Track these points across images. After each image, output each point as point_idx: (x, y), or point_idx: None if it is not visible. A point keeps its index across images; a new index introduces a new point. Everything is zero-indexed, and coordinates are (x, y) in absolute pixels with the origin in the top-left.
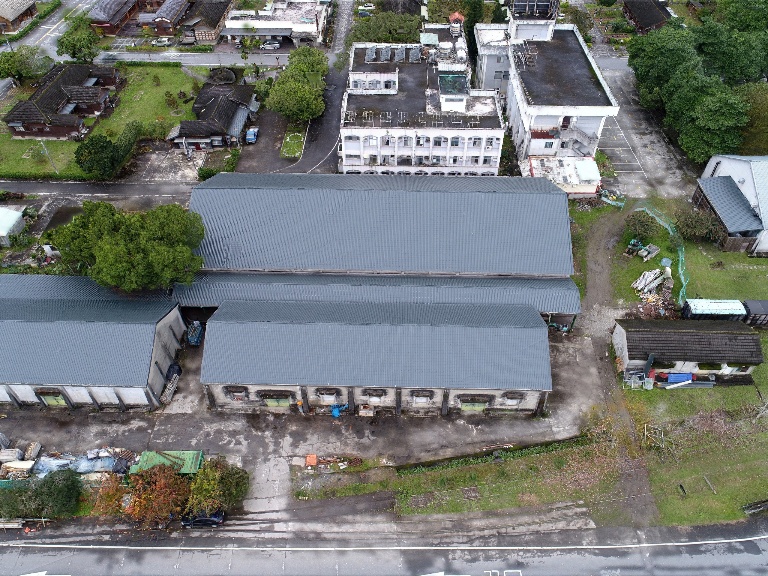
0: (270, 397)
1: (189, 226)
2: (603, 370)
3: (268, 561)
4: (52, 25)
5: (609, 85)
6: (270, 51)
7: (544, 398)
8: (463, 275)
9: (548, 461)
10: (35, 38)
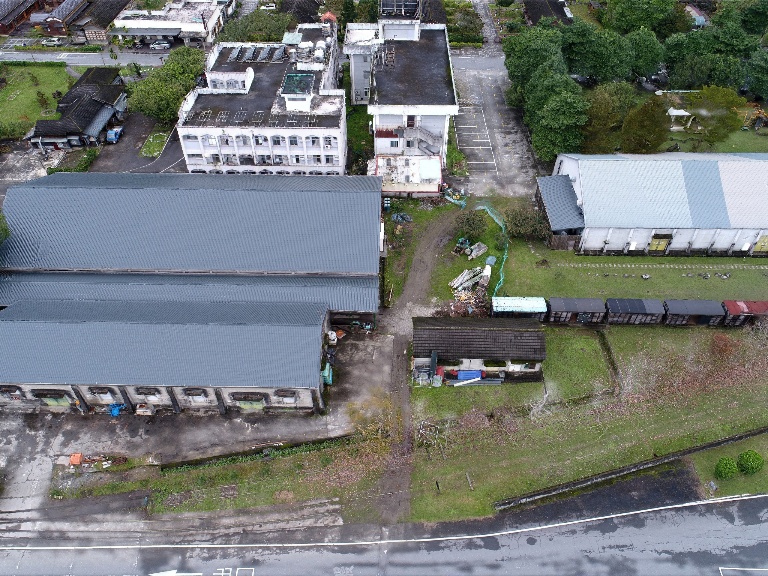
0: (43, 396)
1: None
2: (396, 368)
3: (4, 560)
4: None
5: (489, 85)
6: (160, 51)
7: (315, 396)
8: (271, 274)
9: (316, 459)
10: None
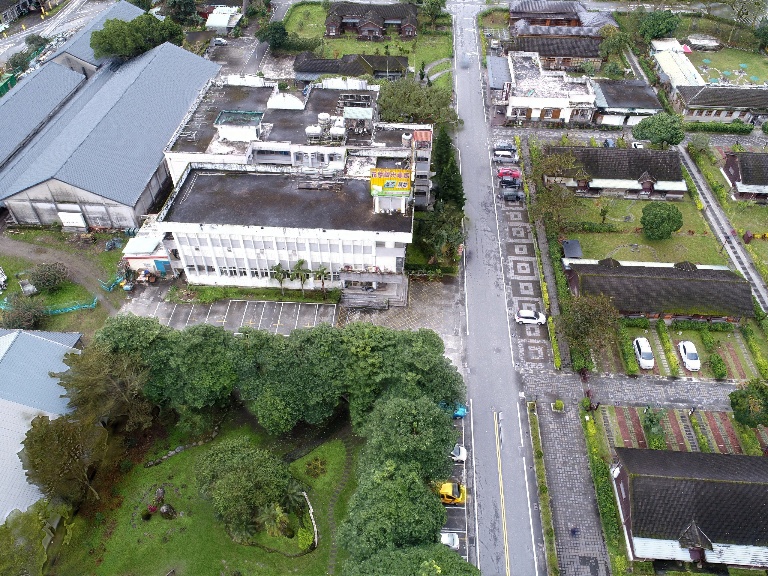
0: None
1: (115, 38)
2: None
3: None
4: None
5: None
6: None
7: None
8: None
9: None
10: None
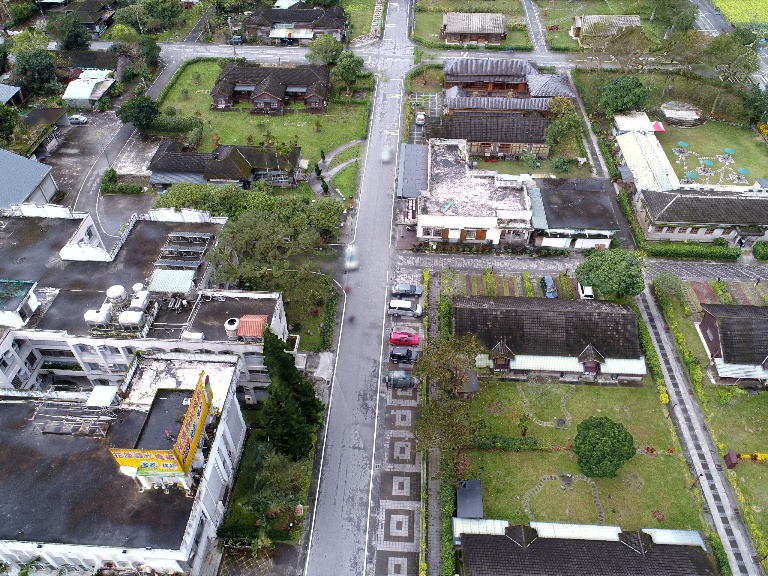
0: None
1: None
2: None
3: None
4: (469, 56)
5: None
6: None
7: None
8: None
9: None
10: (435, 54)
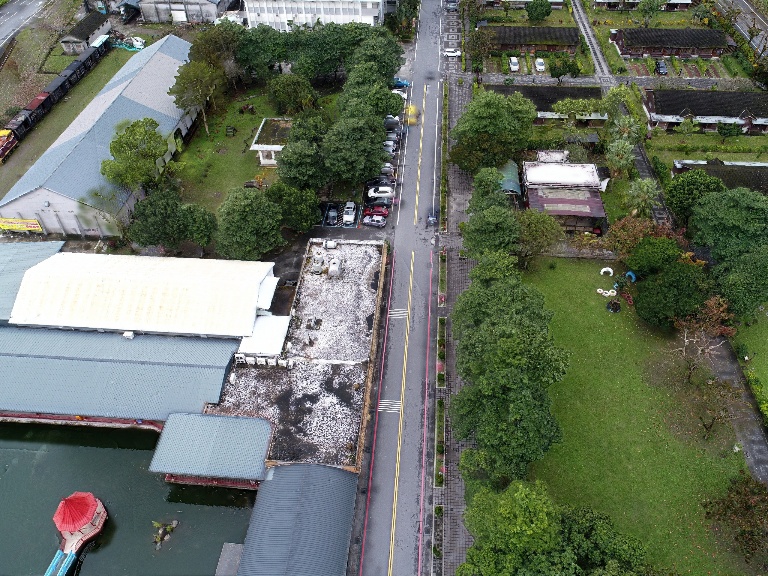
0: None
1: None
2: None
3: None
4: None
5: None
6: None
7: None
8: None
9: None
10: None
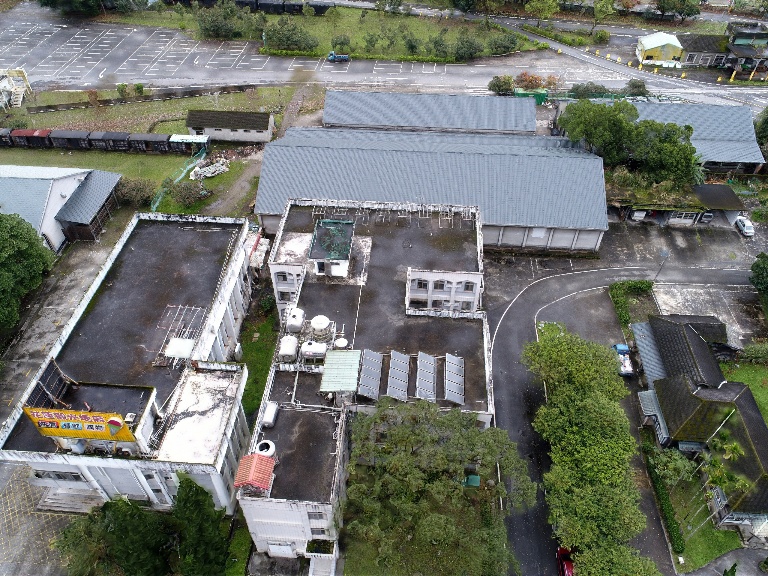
0: None
1: None
2: None
3: None
4: None
5: None
6: None
7: None
8: None
9: None
10: None
